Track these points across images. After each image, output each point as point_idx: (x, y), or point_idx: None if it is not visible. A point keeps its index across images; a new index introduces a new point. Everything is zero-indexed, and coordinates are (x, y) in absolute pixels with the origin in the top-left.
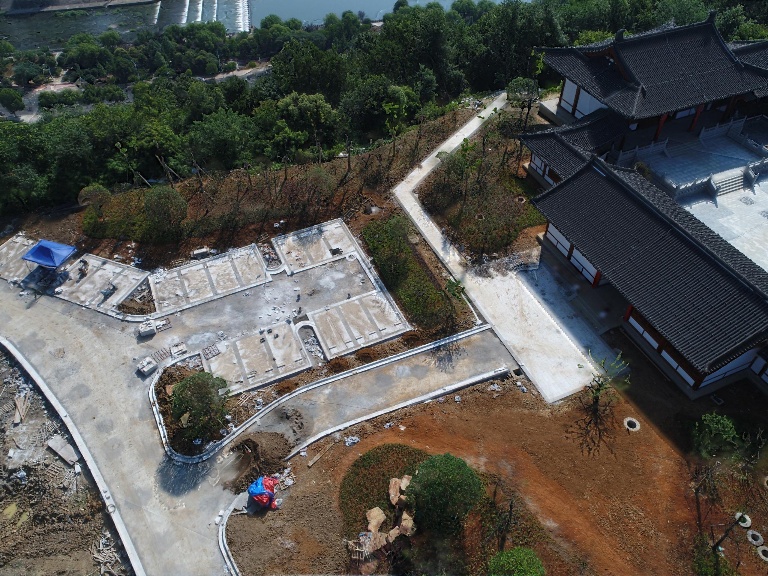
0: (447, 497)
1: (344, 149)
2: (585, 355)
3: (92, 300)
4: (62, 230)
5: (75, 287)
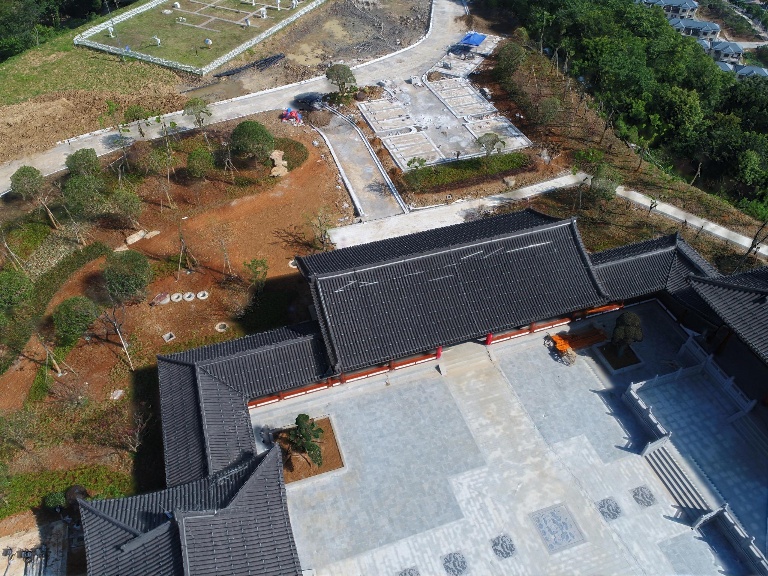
0: None
1: None
2: None
3: (442, 64)
4: None
5: (454, 58)
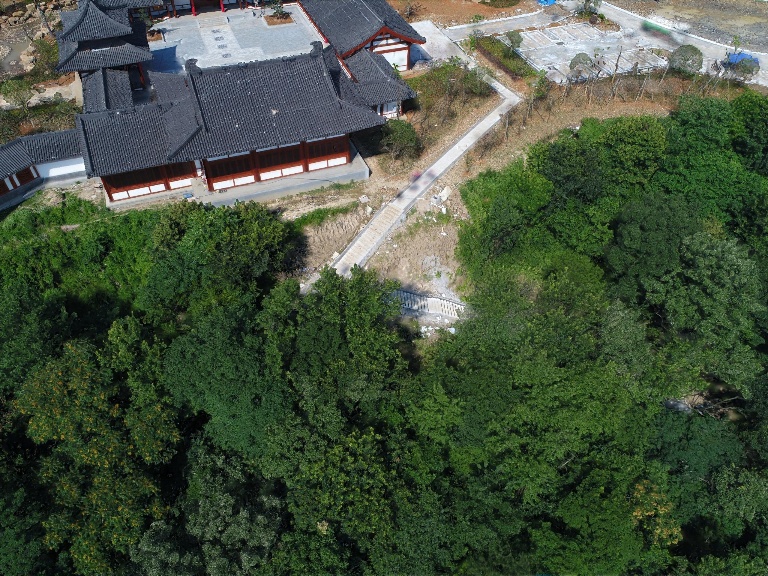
0: None
1: None
2: None
3: None
4: (765, 92)
5: None
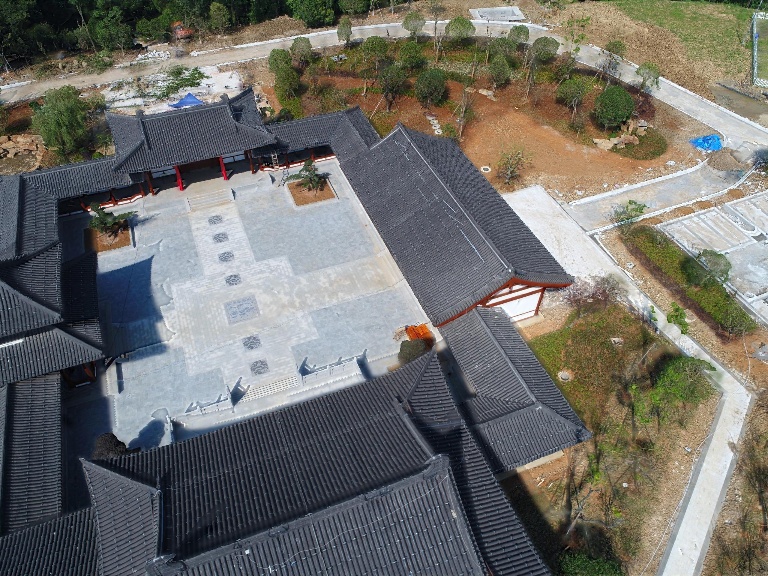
0: None
1: None
2: None
3: None
4: None
5: None
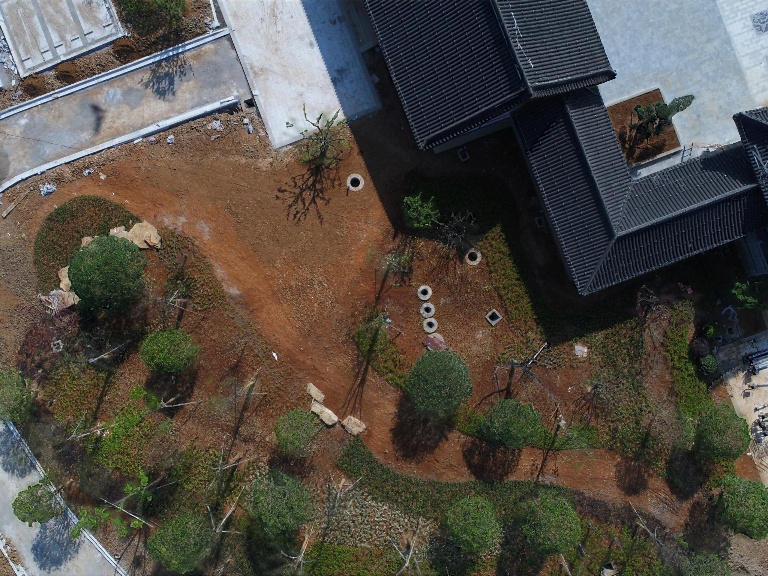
0: (91, 293)
1: None
2: (334, 83)
3: None
4: None
5: None
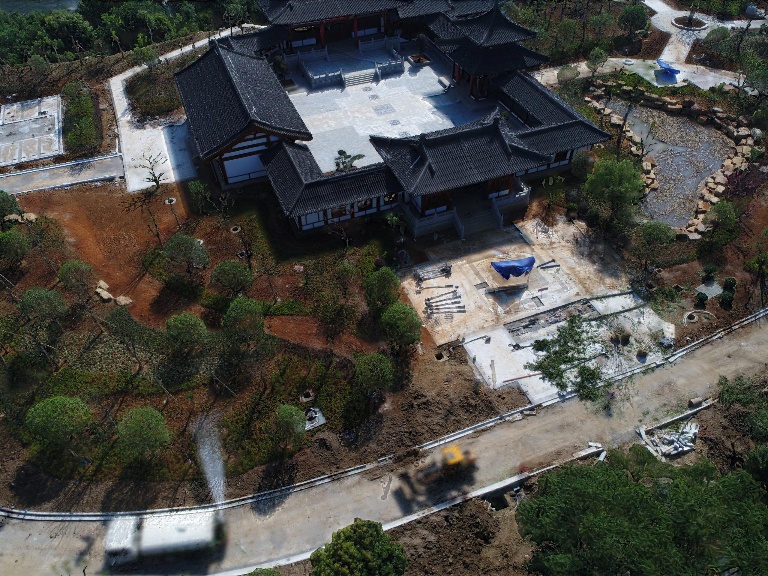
0: None
1: (91, 54)
2: (173, 169)
3: None
4: None
5: None
